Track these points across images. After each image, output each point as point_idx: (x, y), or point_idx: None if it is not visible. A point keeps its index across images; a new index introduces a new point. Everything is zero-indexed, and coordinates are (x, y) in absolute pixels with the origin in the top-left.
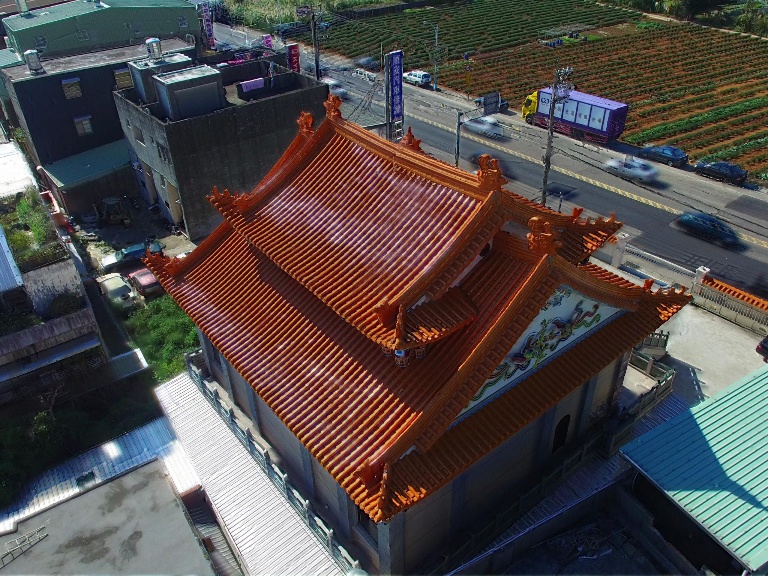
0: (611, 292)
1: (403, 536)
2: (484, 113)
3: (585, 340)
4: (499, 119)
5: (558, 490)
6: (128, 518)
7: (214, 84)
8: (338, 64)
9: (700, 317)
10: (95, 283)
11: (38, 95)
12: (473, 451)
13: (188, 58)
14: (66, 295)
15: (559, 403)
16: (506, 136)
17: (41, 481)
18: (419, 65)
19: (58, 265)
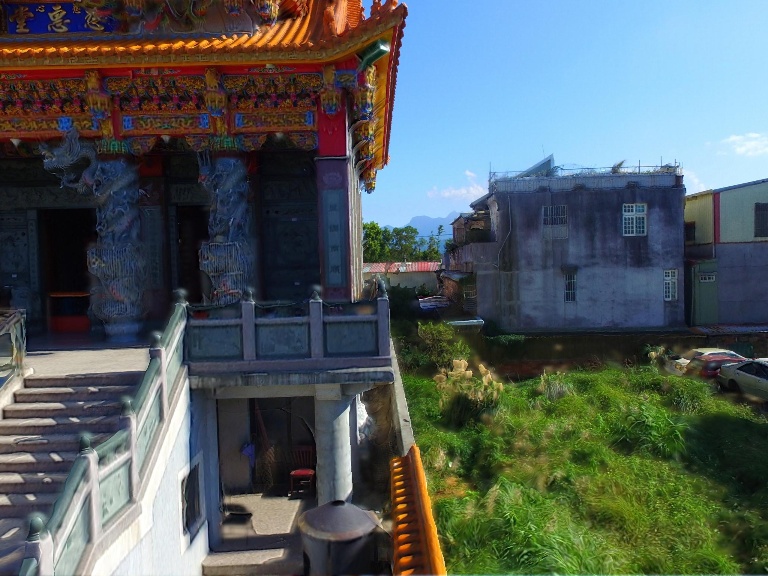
0: None
1: None
2: None
3: None
4: None
5: None
6: None
7: None
8: None
9: None
10: (694, 334)
11: None
12: None
13: None
14: (489, 231)
15: None
16: None
17: None
18: None
19: None
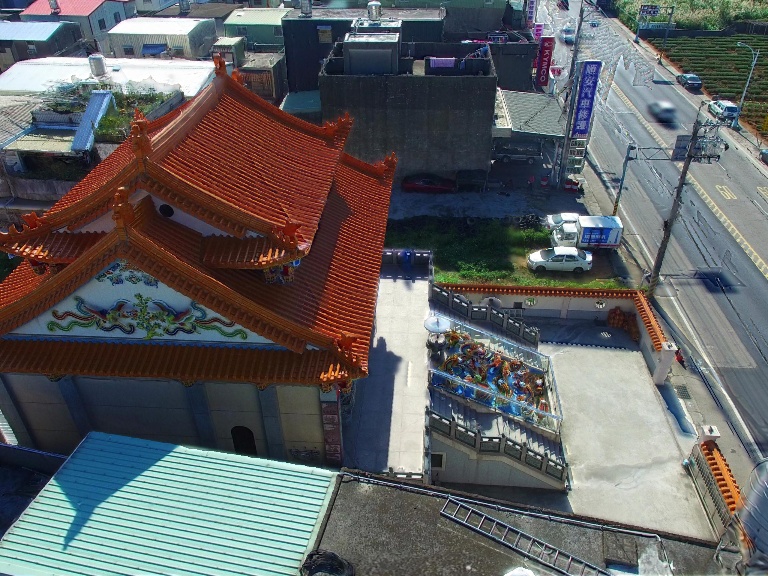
0: (258, 314)
1: (18, 412)
2: (673, 156)
3: (222, 348)
4: (765, 180)
5: None
6: None
7: (389, 51)
8: None
9: (673, 486)
10: None
11: (300, 34)
12: (26, 363)
13: (399, 25)
14: None
15: (221, 405)
16: (654, 186)
17: None
18: (753, 97)
19: None
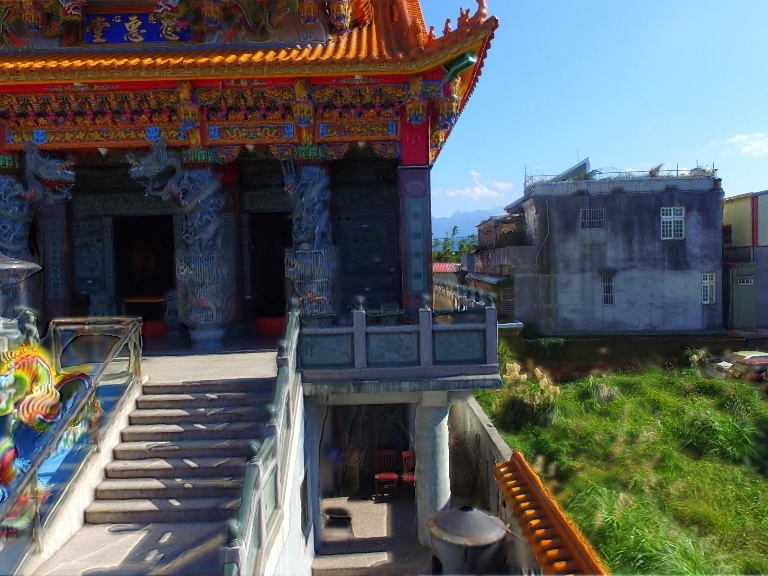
0: None
1: None
2: None
3: None
4: None
5: None
6: None
7: None
8: None
9: None
10: (734, 337)
11: None
12: None
13: None
14: (525, 235)
15: None
16: None
17: None
18: None
19: None
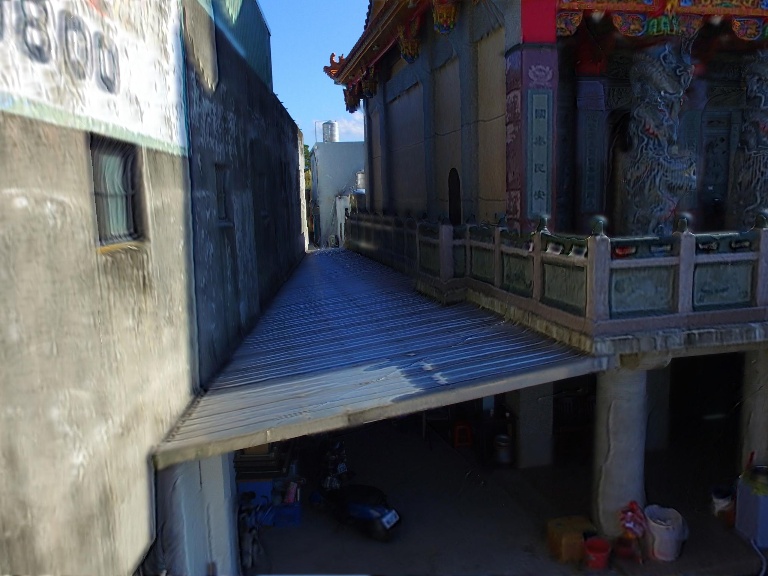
0: None
1: (370, 170)
2: None
3: None
4: None
5: (397, 273)
6: None
7: None
8: None
9: None
10: None
11: None
12: None
13: None
14: None
15: None
16: None
17: None
18: None
19: None
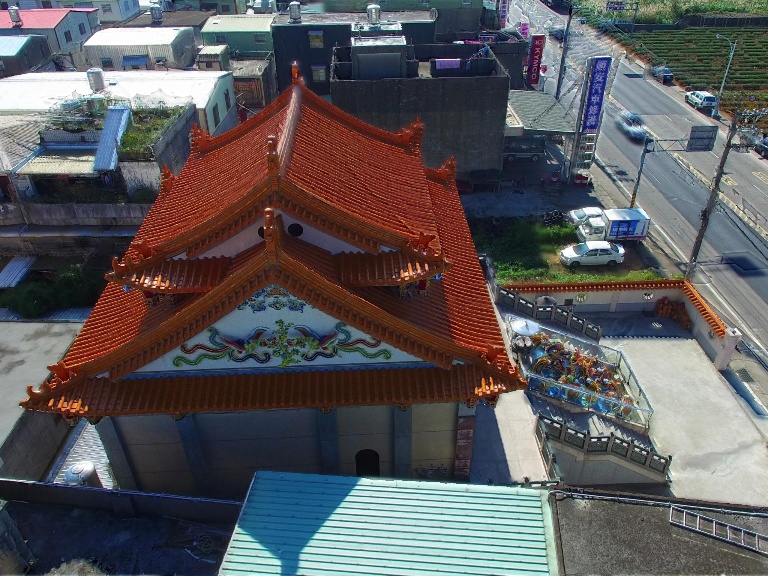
0: (406, 332)
1: (125, 456)
2: (687, 147)
3: (363, 370)
4: (758, 166)
5: None
6: (30, 350)
7: (398, 54)
8: (578, 63)
9: (765, 468)
10: None
11: (290, 40)
12: (155, 403)
13: (400, 28)
14: (148, 189)
15: (350, 429)
16: (681, 177)
17: (62, 313)
18: None
19: (146, 163)
